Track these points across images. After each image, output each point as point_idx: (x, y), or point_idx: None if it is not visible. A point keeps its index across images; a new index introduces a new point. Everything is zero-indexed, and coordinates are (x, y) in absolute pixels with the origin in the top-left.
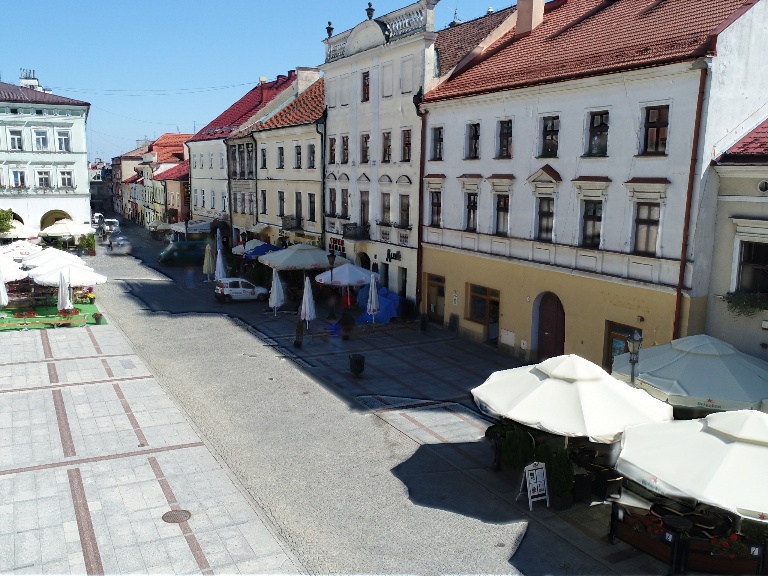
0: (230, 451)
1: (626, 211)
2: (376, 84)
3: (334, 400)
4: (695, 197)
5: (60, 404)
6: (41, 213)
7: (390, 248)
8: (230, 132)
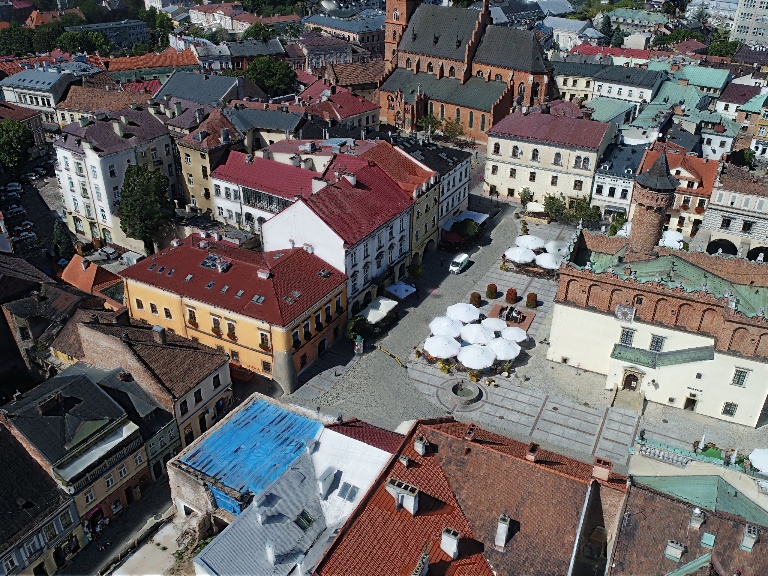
0: (522, 436)
1: None
2: None
3: None
4: None
5: None
6: None
7: None
8: None
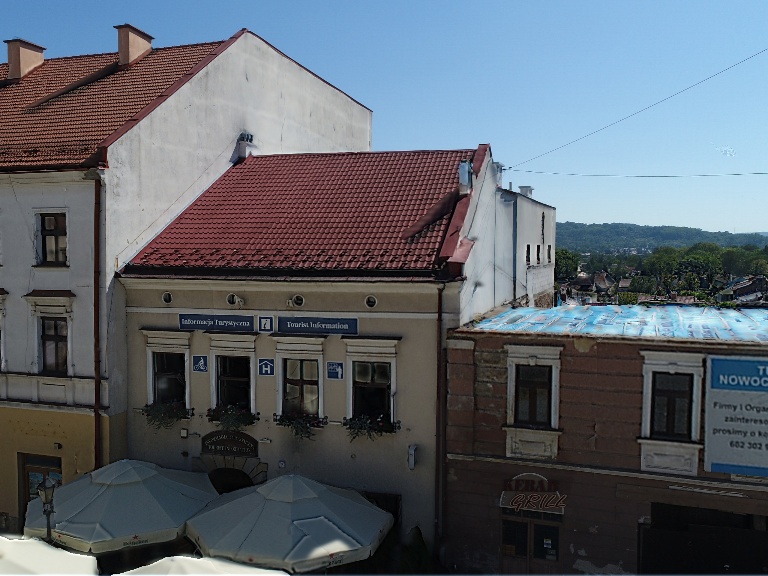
0: None
1: (29, 327)
2: None
3: None
4: (102, 311)
5: None
6: None
7: None
8: None
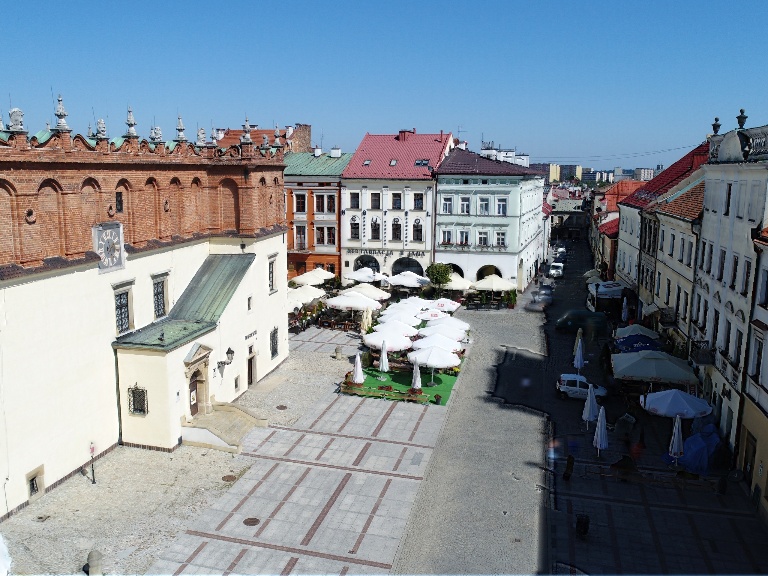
0: None
1: None
2: (734, 201)
3: (532, 559)
4: None
5: (340, 489)
6: (478, 267)
7: (725, 383)
8: (649, 202)
